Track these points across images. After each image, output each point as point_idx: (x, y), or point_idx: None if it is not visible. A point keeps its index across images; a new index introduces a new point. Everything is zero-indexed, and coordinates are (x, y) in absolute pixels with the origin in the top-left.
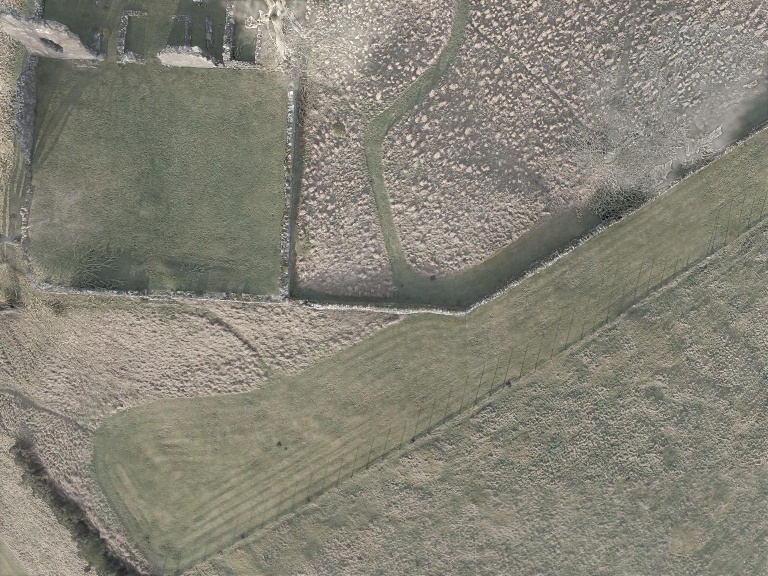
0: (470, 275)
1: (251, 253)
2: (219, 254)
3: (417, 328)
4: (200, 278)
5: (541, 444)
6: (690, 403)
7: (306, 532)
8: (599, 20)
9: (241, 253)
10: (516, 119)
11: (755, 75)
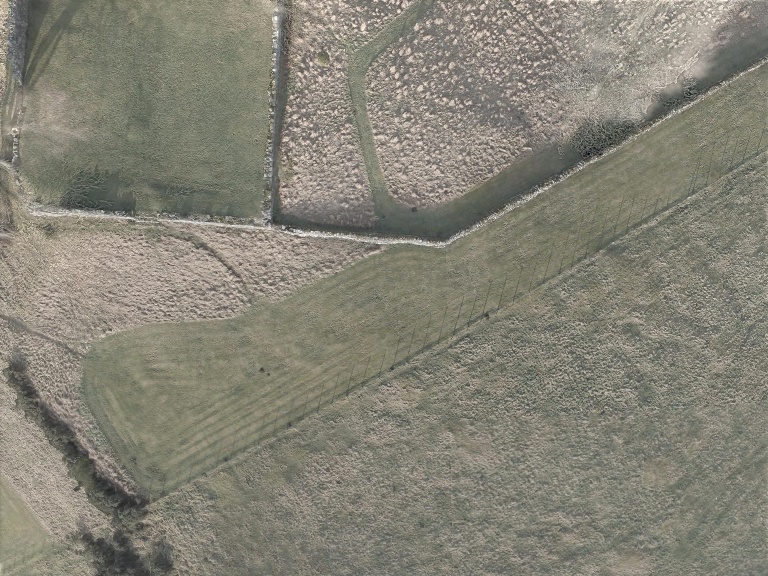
0: (451, 208)
1: (235, 177)
2: (204, 178)
3: (398, 259)
4: (185, 201)
5: (518, 376)
6: (666, 341)
7: (287, 456)
8: None
9: (225, 177)
10: (500, 55)
11: (742, 18)
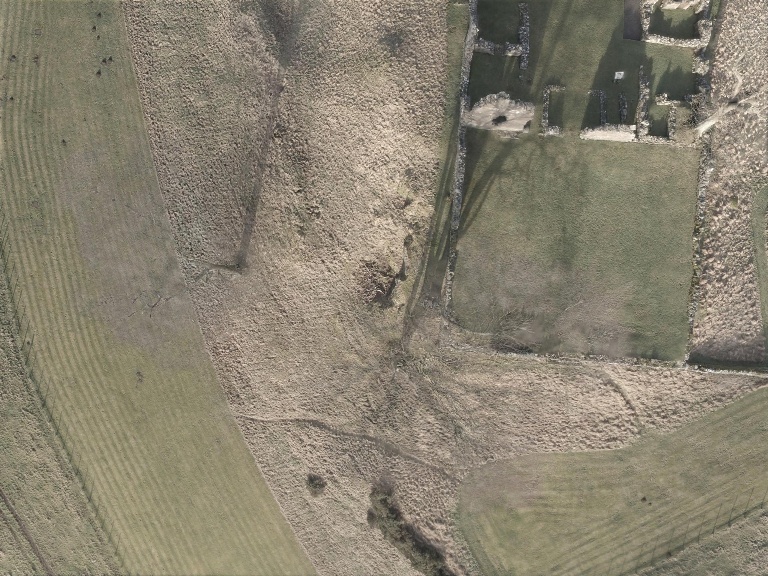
0: None
1: (658, 320)
2: (627, 320)
3: None
4: (610, 343)
5: None
6: None
7: None
8: None
9: (648, 320)
10: None
11: None
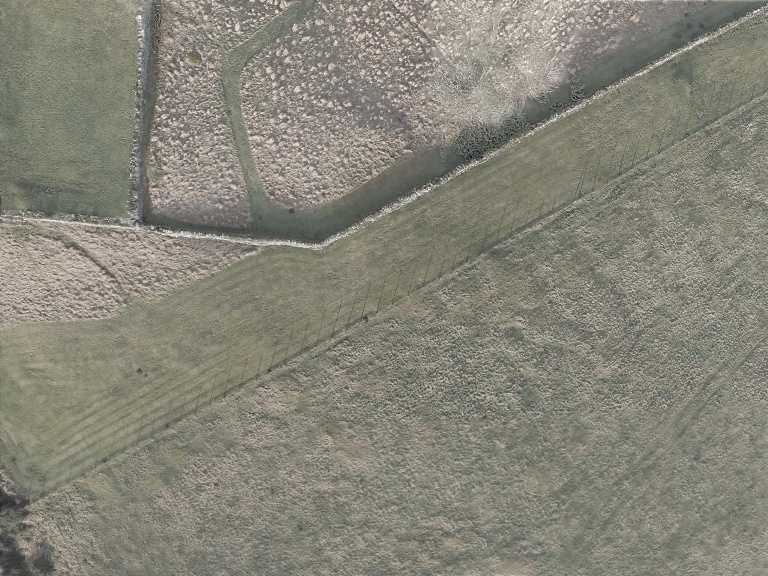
0: (329, 209)
1: (101, 176)
2: (70, 177)
3: (275, 260)
4: (51, 199)
5: (397, 379)
6: (551, 345)
7: (165, 457)
8: None
9: (92, 176)
10: (382, 57)
11: (633, 22)
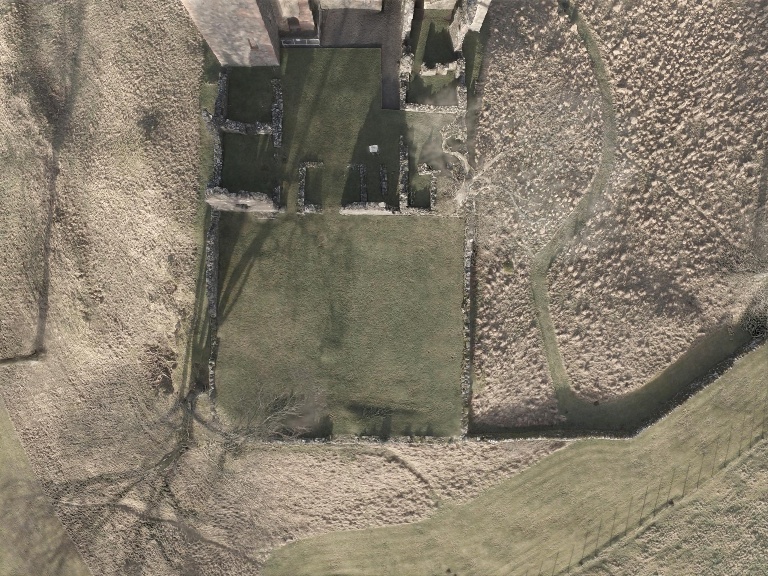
0: (632, 399)
1: (432, 395)
2: (400, 397)
3: (582, 453)
4: (383, 422)
5: (704, 561)
6: None
7: None
8: (739, 139)
9: (422, 395)
10: (667, 241)
11: None
